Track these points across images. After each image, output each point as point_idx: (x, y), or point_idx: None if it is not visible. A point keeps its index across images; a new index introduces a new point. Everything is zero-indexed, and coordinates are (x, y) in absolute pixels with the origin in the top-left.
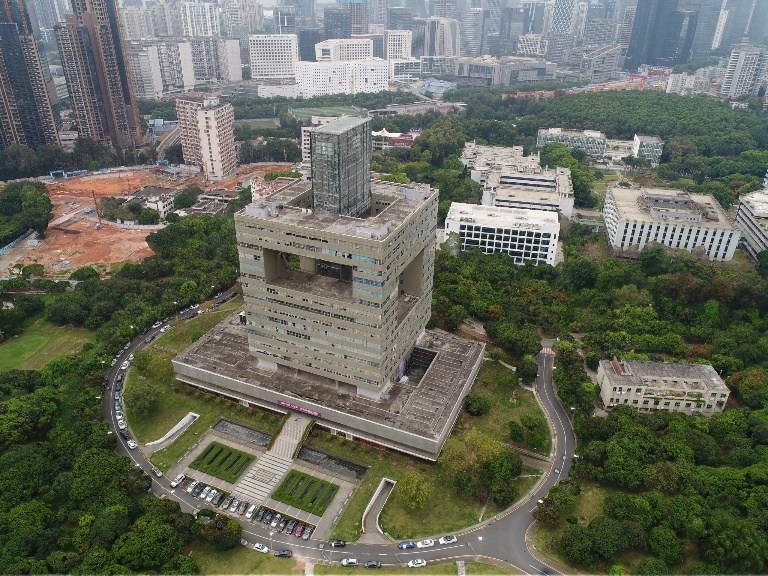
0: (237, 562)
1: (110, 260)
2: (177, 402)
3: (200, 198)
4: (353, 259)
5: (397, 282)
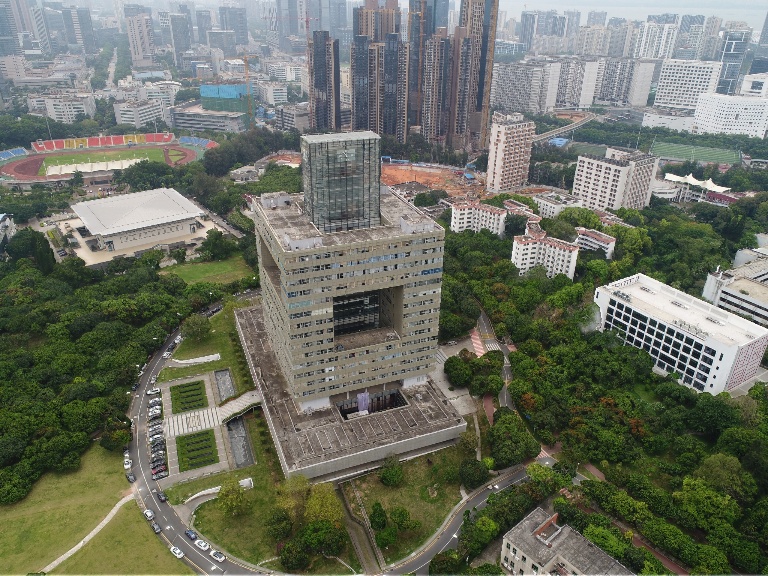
0: (107, 462)
1: None
2: (222, 343)
3: (440, 202)
4: (279, 263)
5: (329, 303)
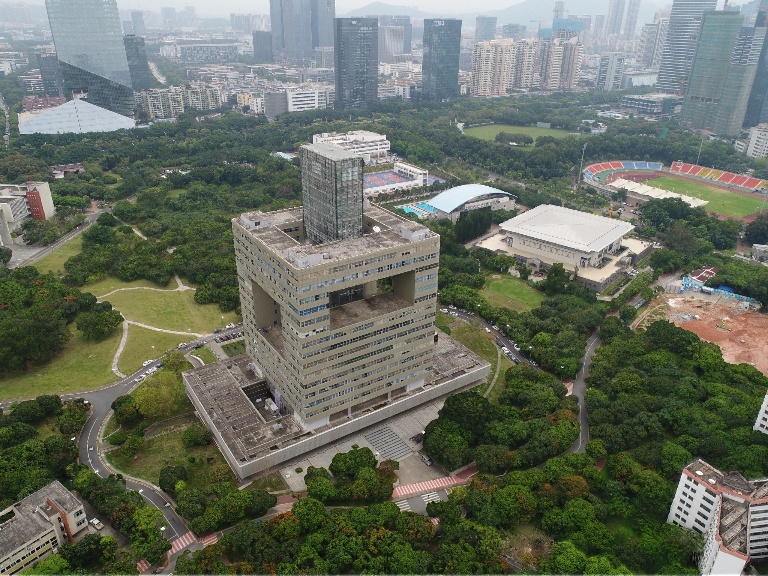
0: (232, 319)
1: None
2: None
3: None
4: None
5: None
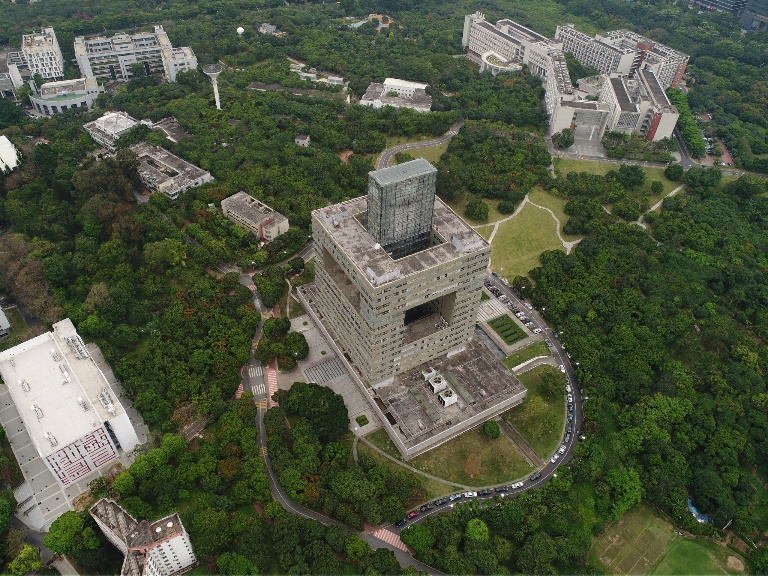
0: None
1: None
2: None
3: None
4: None
5: None
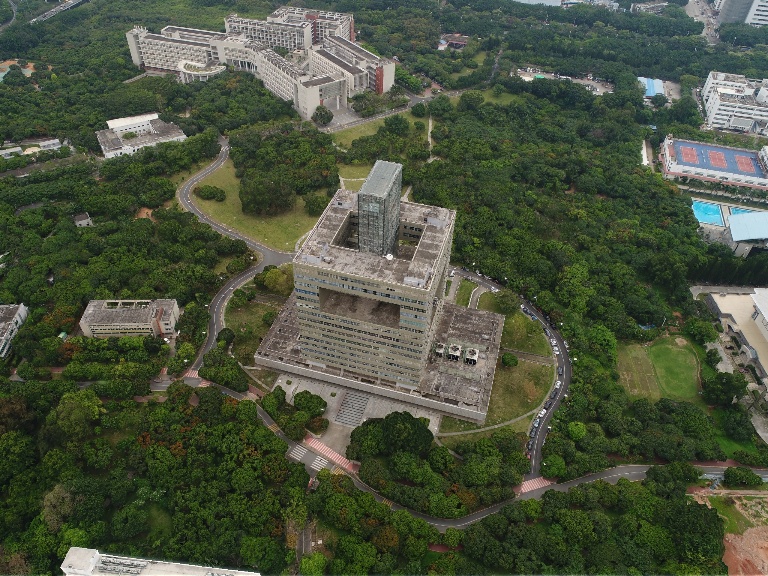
0: None
1: None
2: None
3: None
4: None
5: None
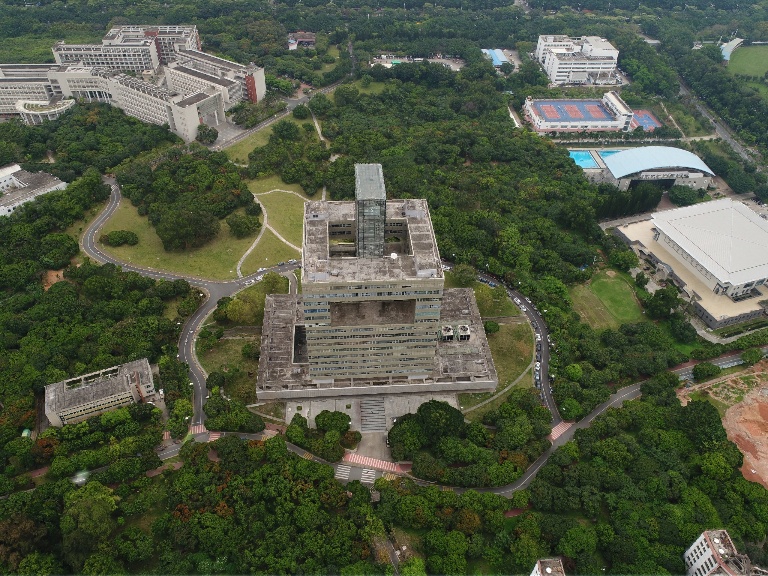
0: None
1: (762, 429)
2: None
3: None
4: None
5: None
